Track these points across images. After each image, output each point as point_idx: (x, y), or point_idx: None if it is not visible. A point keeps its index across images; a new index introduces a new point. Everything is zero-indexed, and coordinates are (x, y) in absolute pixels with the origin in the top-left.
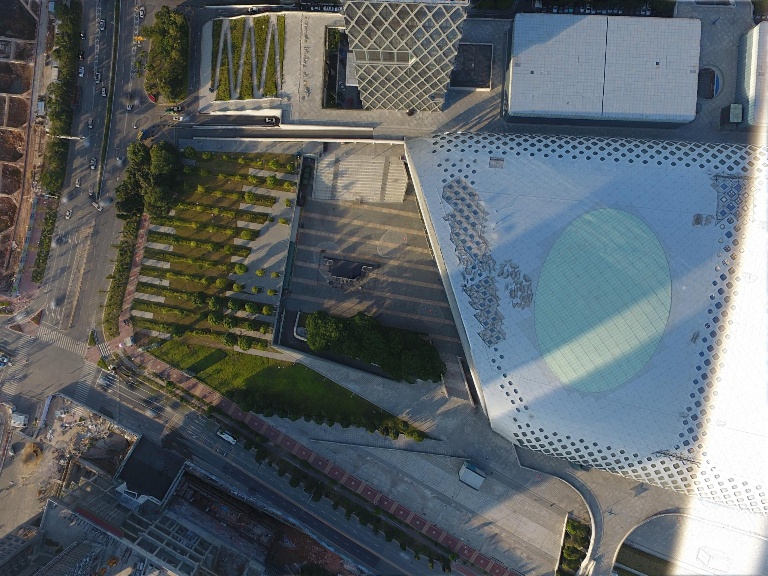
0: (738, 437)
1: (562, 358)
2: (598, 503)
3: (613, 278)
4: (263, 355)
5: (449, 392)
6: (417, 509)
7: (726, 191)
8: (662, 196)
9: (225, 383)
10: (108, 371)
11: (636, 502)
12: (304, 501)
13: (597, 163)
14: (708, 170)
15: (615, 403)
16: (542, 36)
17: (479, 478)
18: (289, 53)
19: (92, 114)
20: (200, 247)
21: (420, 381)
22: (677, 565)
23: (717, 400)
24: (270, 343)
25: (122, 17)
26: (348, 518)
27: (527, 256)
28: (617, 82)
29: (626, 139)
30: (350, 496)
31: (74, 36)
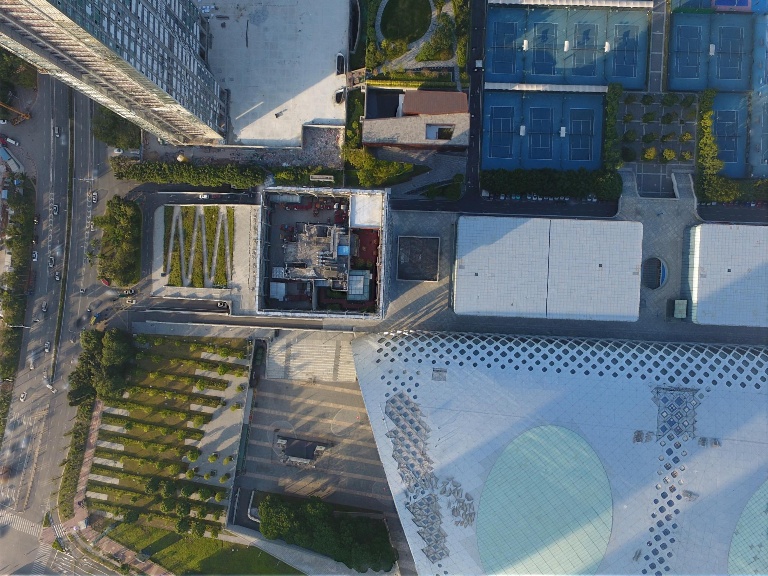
0: None
1: (505, 575)
2: None
3: (554, 498)
4: (217, 538)
5: (403, 574)
6: None
7: (667, 405)
8: (603, 411)
9: (180, 564)
10: (63, 552)
11: None
12: None
13: (539, 375)
14: (649, 382)
15: None
16: (486, 238)
17: None
18: (238, 244)
19: (46, 297)
20: (154, 430)
21: None
22: None
23: None
24: (224, 526)
25: (75, 202)
26: None
27: (469, 474)
28: (560, 284)
29: (570, 343)
30: None
31: (27, 224)
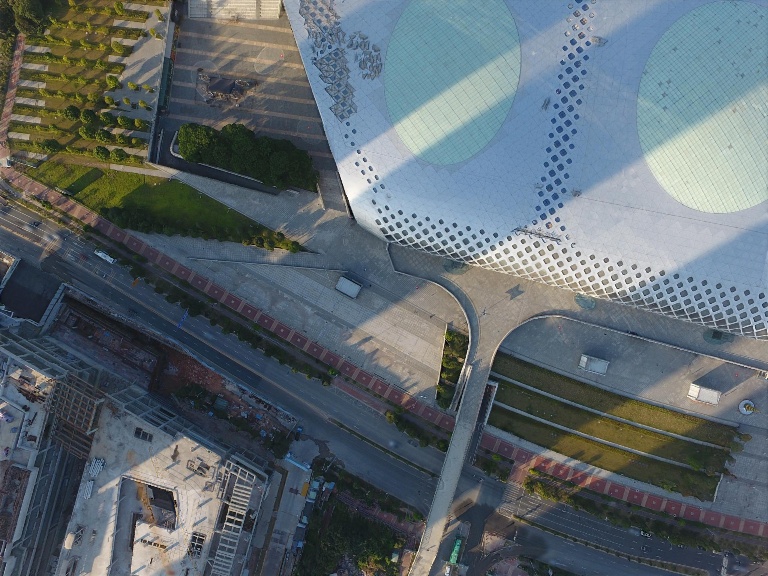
0: (594, 207)
1: (413, 129)
2: (474, 307)
3: (461, 44)
4: (139, 172)
5: (326, 205)
6: (298, 326)
7: None
8: None
9: (102, 203)
10: None
11: (512, 305)
12: (184, 322)
13: None
14: None
15: (469, 176)
16: None
17: (354, 286)
18: None
19: None
20: (75, 65)
21: (296, 194)
22: (559, 374)
23: (571, 168)
24: (146, 159)
25: None
26: (224, 331)
27: (376, 26)
28: None
29: None
30: (230, 315)
31: None
